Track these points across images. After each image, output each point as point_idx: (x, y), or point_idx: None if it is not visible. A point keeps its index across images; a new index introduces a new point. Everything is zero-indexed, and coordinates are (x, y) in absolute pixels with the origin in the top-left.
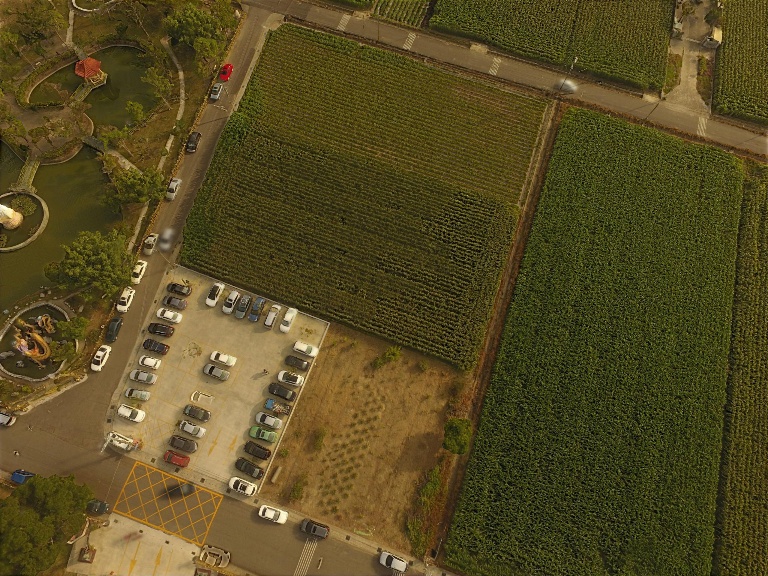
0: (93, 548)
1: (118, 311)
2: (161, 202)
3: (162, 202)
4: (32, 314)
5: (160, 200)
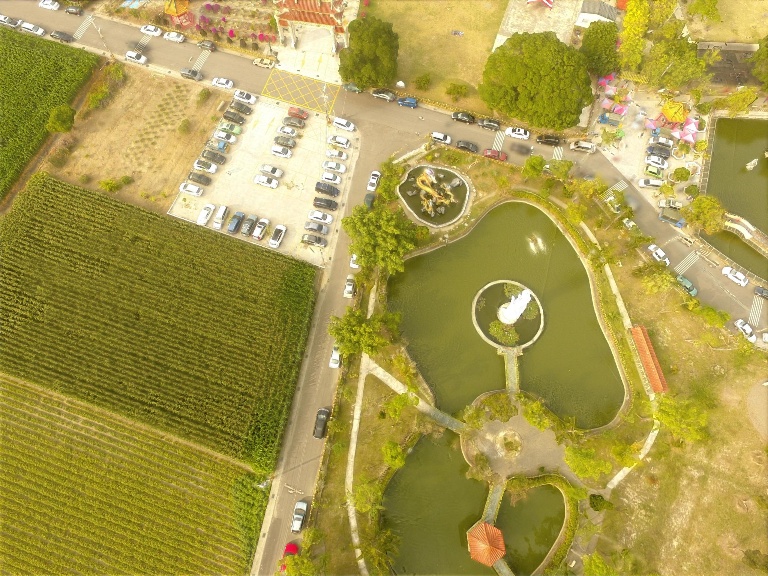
0: None
1: None
2: None
3: None
4: (448, 217)
5: None
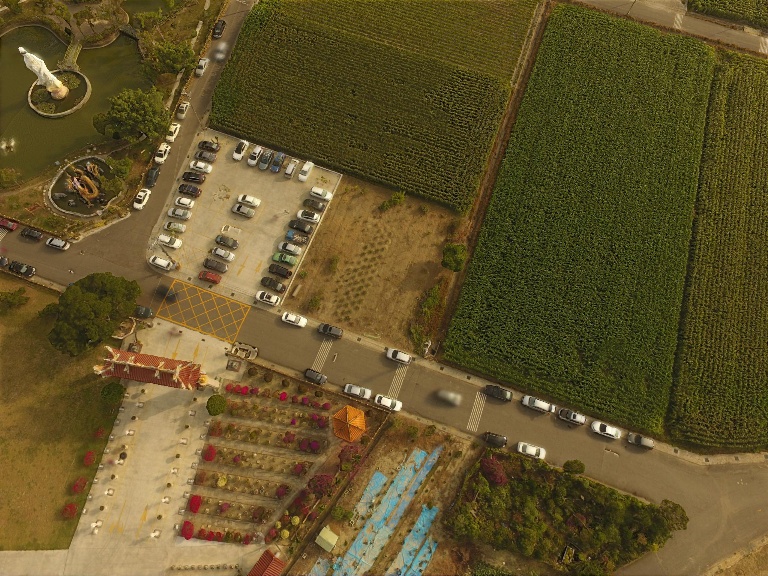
0: (140, 343)
1: (156, 162)
2: (191, 77)
3: (192, 77)
4: None
5: (191, 75)
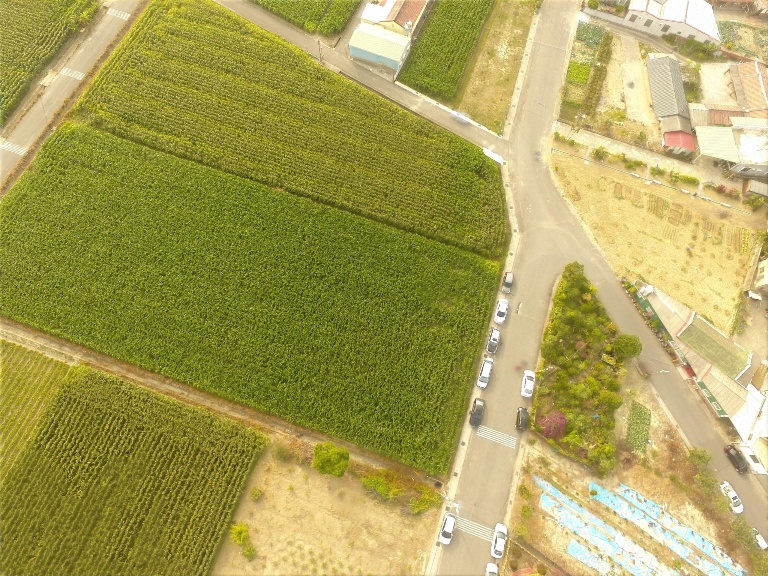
0: None
1: None
2: None
3: None
4: None
5: None
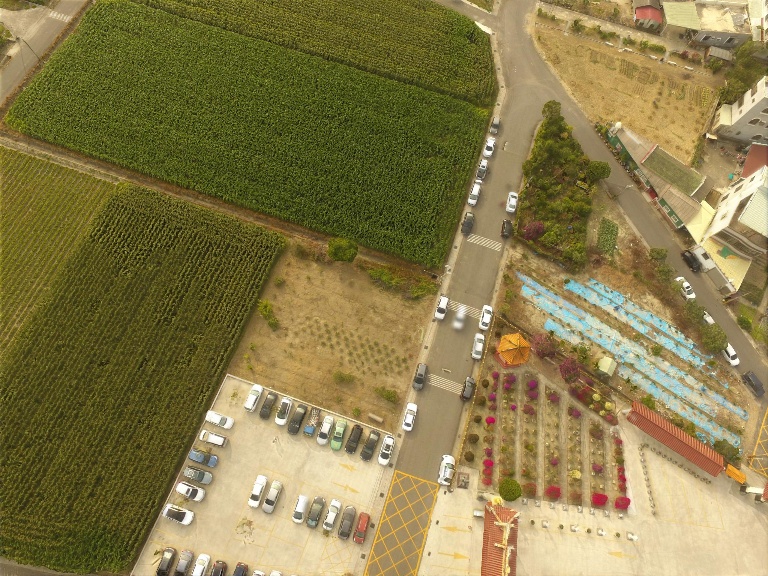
0: None
1: None
2: None
3: None
4: None
5: None
